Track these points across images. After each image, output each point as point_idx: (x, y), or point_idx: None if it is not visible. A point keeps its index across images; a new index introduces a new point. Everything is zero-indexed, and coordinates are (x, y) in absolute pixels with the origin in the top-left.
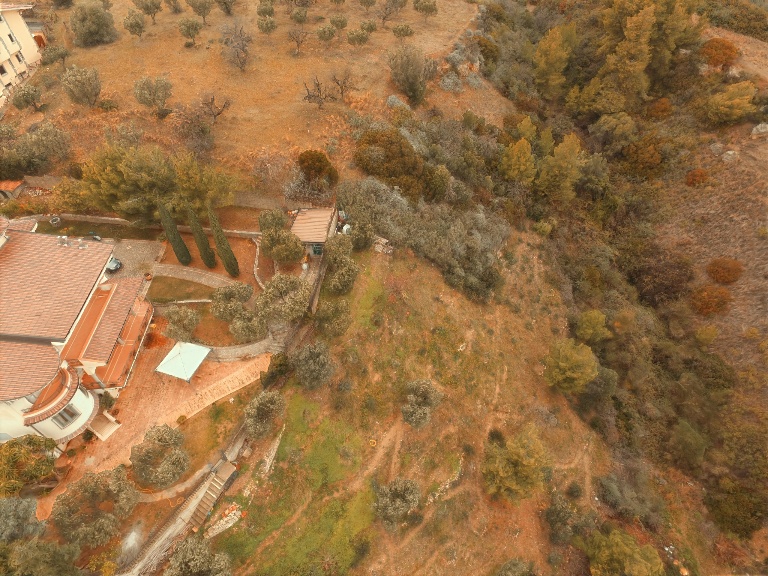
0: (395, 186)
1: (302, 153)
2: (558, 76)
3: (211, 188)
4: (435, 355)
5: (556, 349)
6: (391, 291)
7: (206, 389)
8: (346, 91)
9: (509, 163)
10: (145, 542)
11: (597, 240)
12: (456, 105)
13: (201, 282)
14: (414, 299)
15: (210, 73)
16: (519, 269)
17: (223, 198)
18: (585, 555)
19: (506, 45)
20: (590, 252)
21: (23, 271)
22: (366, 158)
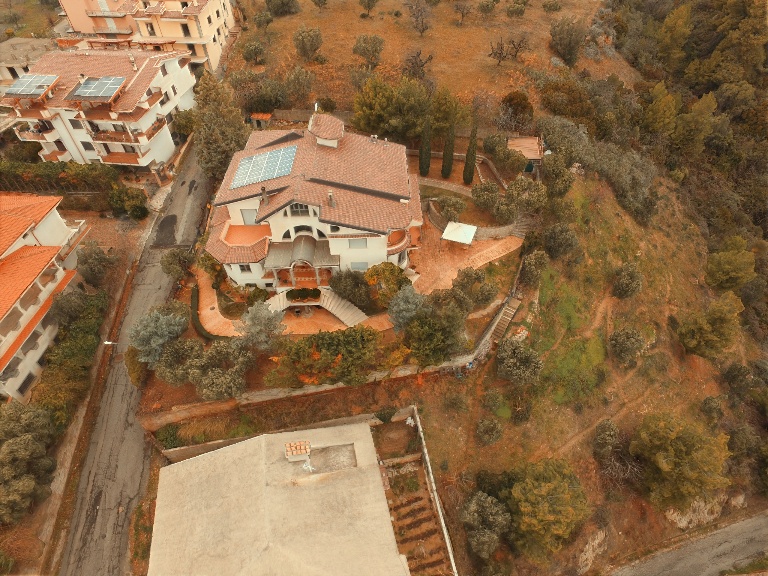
0: (580, 124)
1: (510, 93)
2: (679, 51)
3: (456, 112)
4: (623, 255)
5: (715, 259)
6: (590, 201)
7: (474, 256)
8: (521, 51)
9: (654, 117)
10: (474, 340)
11: (724, 188)
12: (598, 70)
13: (442, 187)
14: (603, 211)
15: (393, 37)
16: (663, 205)
17: (461, 122)
18: (755, 409)
19: (630, 23)
20: (720, 196)
21: (360, 155)
22: (554, 101)
